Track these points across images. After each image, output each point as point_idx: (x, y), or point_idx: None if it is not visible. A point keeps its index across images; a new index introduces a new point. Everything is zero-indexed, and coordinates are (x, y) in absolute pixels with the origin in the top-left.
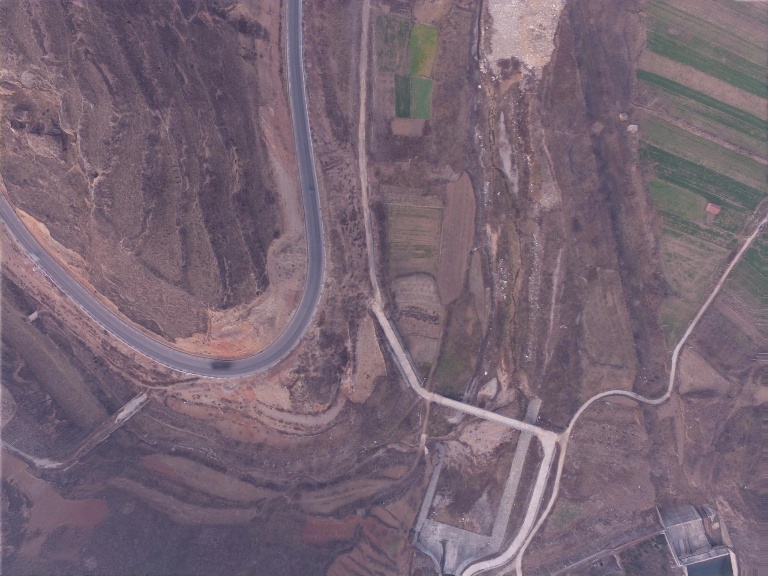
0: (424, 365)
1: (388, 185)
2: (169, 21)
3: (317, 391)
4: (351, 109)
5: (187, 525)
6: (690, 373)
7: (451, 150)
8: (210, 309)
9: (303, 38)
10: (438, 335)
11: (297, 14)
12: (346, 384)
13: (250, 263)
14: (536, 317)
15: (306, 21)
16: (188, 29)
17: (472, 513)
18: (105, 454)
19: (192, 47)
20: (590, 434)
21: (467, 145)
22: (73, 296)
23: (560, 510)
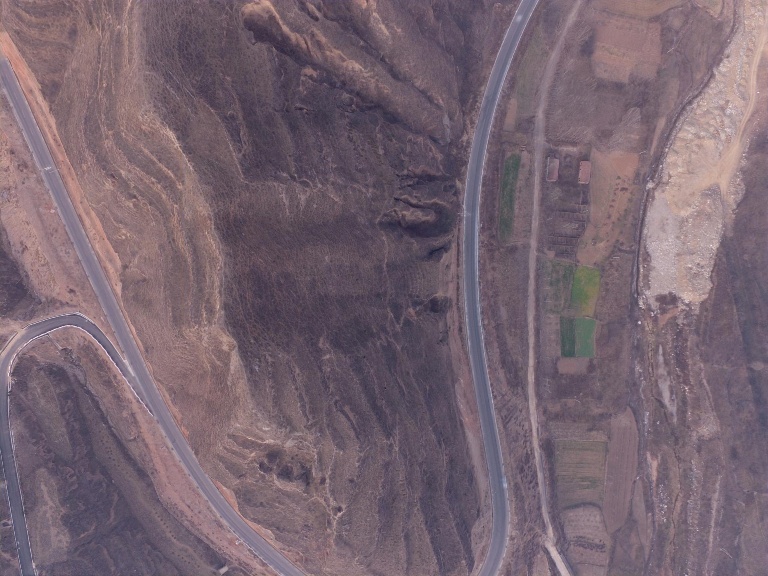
0: None
1: (555, 422)
2: (388, 335)
3: None
4: (520, 353)
5: None
6: None
7: (614, 386)
8: None
9: (480, 296)
10: (604, 562)
11: (474, 273)
12: None
13: (462, 551)
14: (696, 539)
15: (482, 279)
16: (401, 335)
17: None
18: None
19: (406, 354)
20: None
21: (629, 380)
22: (274, 565)
23: None
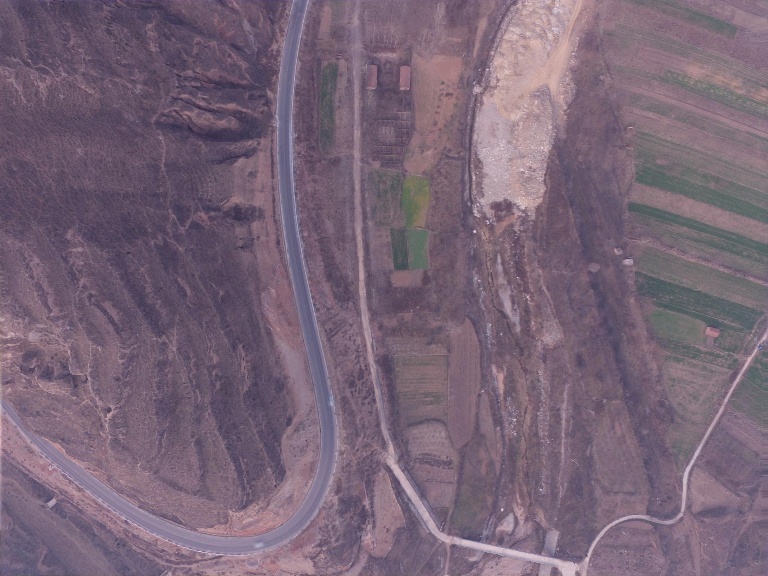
0: (441, 510)
1: (392, 337)
2: (167, 236)
3: (340, 557)
4: (350, 267)
5: None
6: (701, 492)
7: (451, 297)
8: (230, 510)
9: (297, 208)
10: (453, 479)
11: (289, 184)
12: (367, 540)
13: (266, 459)
14: (547, 451)
15: (299, 190)
16: (186, 237)
17: None
18: None
19: (191, 256)
20: (608, 561)
21: (467, 290)
22: (91, 490)
23: None
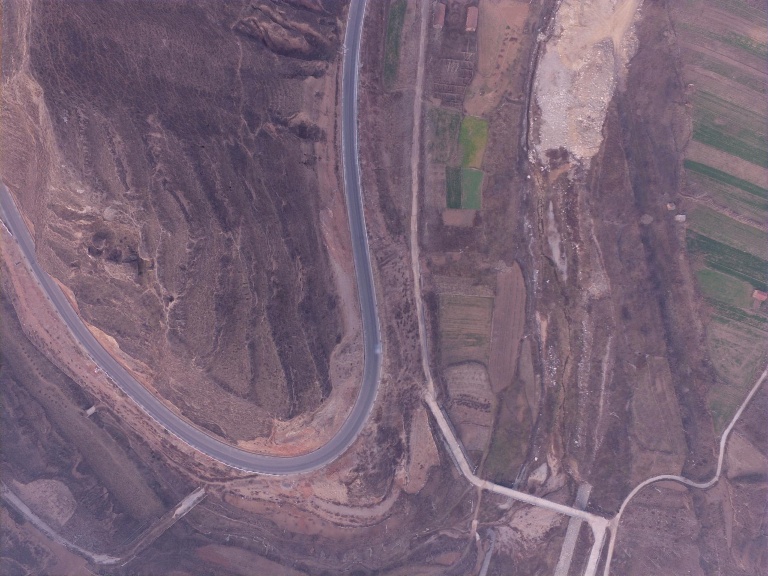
0: (476, 453)
1: (439, 275)
2: (238, 138)
3: (374, 486)
4: (403, 201)
5: None
6: (738, 457)
7: (501, 240)
8: (276, 419)
9: (358, 136)
10: (489, 423)
11: (352, 112)
12: (400, 475)
13: (315, 371)
14: (586, 403)
15: (361, 119)
16: (255, 143)
17: None
18: (161, 546)
19: (259, 161)
20: (640, 519)
21: (517, 235)
22: (134, 396)
23: None
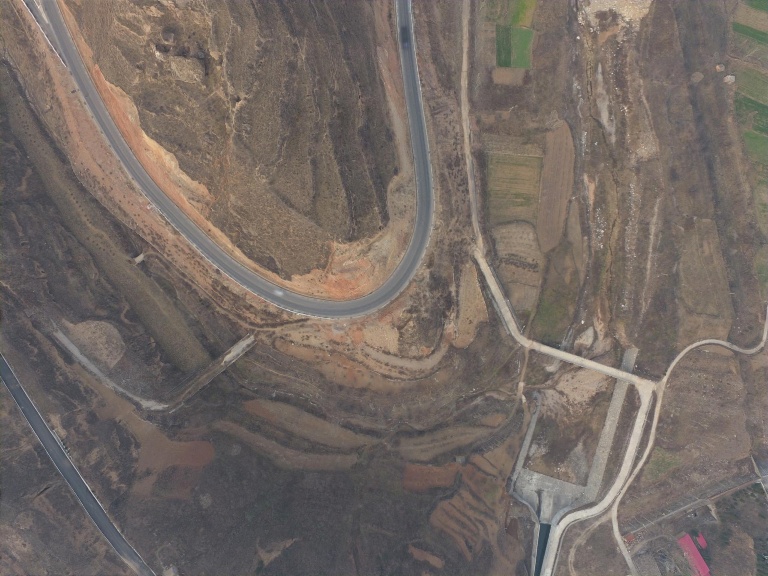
0: (523, 312)
1: (488, 133)
2: None
3: (426, 333)
4: (454, 57)
5: (289, 470)
6: None
7: (551, 99)
8: (336, 241)
9: None
10: (537, 283)
11: None
12: (449, 329)
13: (374, 197)
14: (633, 266)
15: None
16: None
17: (567, 463)
18: (207, 398)
19: None
20: (686, 383)
21: (566, 95)
22: (187, 235)
23: (656, 459)
